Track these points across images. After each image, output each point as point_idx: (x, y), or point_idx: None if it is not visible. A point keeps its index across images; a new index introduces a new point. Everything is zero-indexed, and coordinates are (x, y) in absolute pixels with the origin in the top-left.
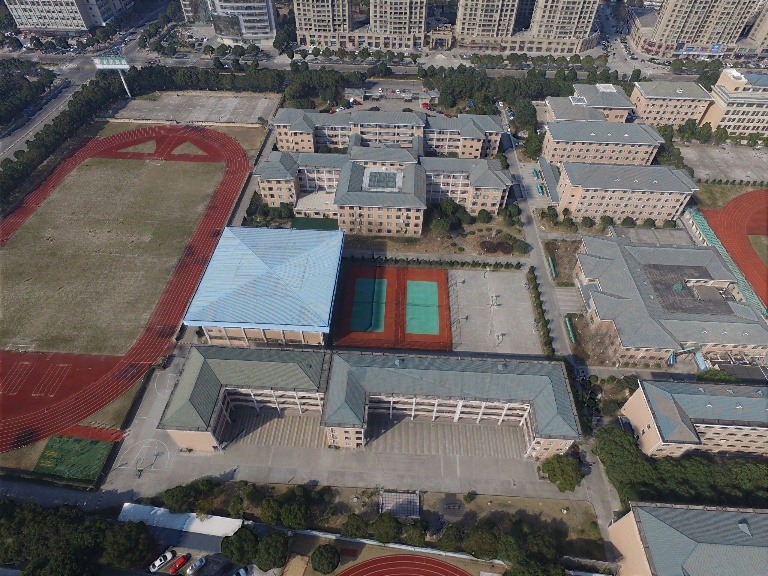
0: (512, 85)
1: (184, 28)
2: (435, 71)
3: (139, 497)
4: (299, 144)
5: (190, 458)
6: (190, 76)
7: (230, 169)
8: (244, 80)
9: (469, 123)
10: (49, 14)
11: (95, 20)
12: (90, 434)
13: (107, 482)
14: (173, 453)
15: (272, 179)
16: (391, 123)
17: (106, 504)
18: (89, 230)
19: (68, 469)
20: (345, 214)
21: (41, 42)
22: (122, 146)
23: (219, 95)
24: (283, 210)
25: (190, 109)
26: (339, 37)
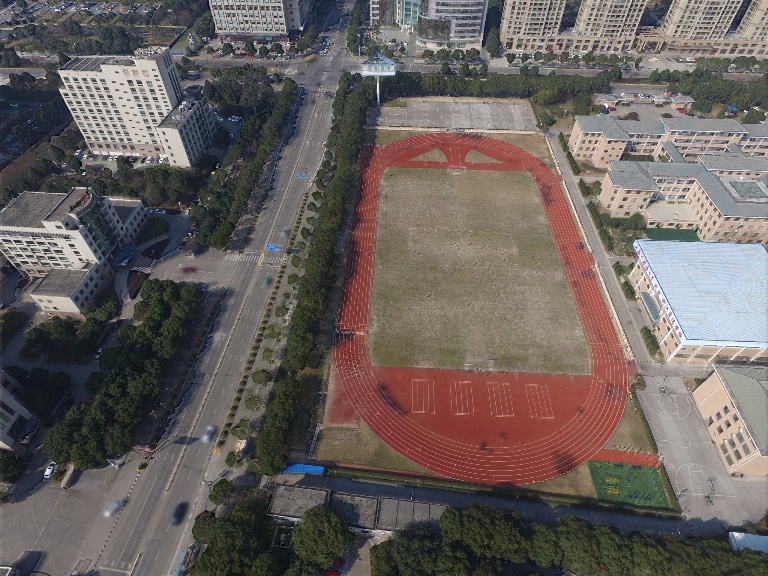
0: None
1: (374, 32)
2: (669, 75)
3: (729, 525)
4: (608, 152)
5: (747, 483)
6: (438, 82)
7: (539, 178)
8: (493, 86)
9: None
10: (252, 19)
11: (292, 24)
12: (625, 458)
13: (683, 509)
14: (725, 478)
15: (636, 190)
16: (714, 130)
17: (702, 533)
18: (449, 243)
19: (633, 496)
20: (725, 225)
21: (254, 47)
22: (410, 155)
23: (465, 101)
24: (640, 221)
25: (447, 116)
26: (548, 40)
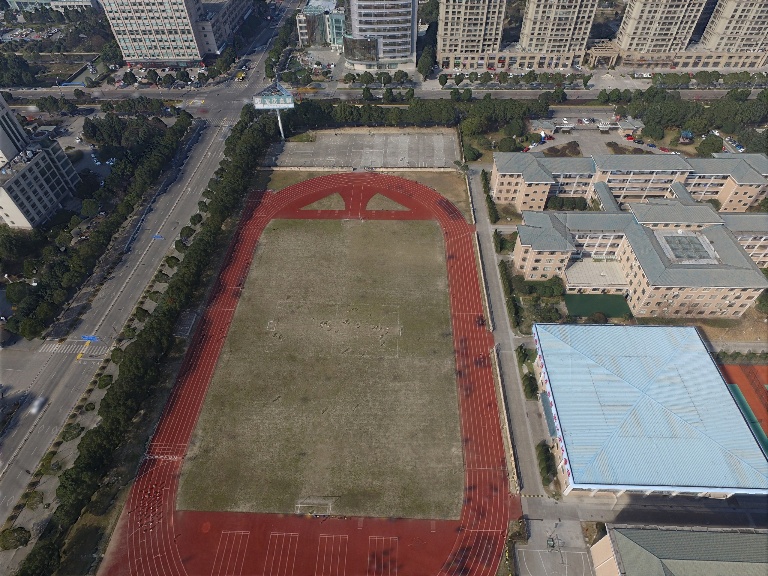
0: (733, 111)
1: (301, 53)
2: (619, 95)
3: None
4: (529, 196)
5: None
6: (351, 112)
7: (448, 229)
8: (414, 114)
9: (742, 165)
10: (161, 44)
11: (208, 48)
12: None
13: None
14: None
15: (548, 250)
16: (652, 169)
17: None
18: (320, 321)
19: None
20: (656, 295)
21: (159, 76)
22: (304, 202)
23: (383, 132)
24: (556, 287)
25: (359, 151)
26: (488, 58)
